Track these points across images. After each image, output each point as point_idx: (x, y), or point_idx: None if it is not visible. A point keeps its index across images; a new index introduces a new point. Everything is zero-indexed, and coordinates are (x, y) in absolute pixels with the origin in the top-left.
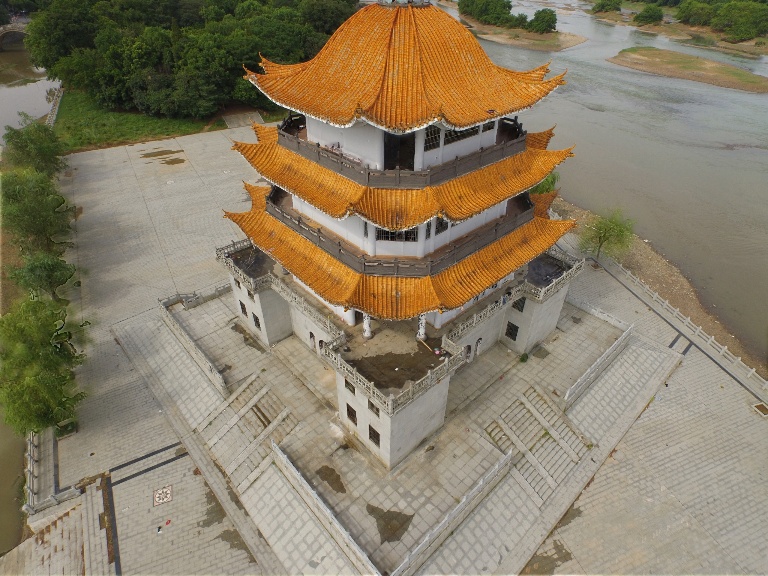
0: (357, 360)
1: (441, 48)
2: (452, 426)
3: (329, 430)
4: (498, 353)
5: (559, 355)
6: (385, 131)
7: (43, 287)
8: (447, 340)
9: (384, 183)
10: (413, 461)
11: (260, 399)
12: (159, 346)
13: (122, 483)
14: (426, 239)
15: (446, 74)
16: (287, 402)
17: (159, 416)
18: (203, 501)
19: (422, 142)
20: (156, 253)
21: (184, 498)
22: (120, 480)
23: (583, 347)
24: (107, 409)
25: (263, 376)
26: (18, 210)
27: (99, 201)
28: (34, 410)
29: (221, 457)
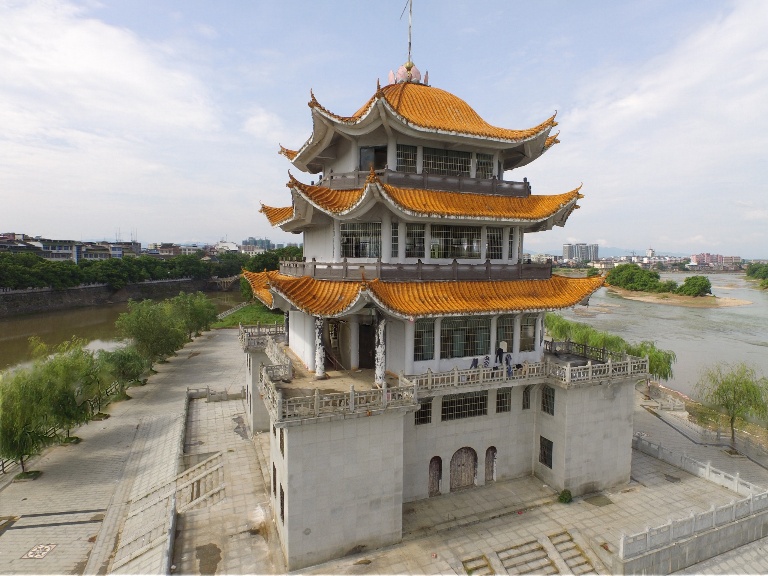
0: (289, 388)
1: (425, 100)
2: (414, 546)
3: (250, 512)
4: (526, 485)
5: (628, 507)
6: (361, 155)
7: (117, 377)
8: (403, 379)
9: (344, 185)
10: (329, 569)
11: (207, 475)
12: (165, 431)
13: (19, 529)
14: (392, 257)
15: (425, 113)
16: (229, 479)
17: (112, 484)
18: (69, 569)
19: (393, 160)
20: (227, 381)
21: (55, 560)
22: (20, 526)
23: (675, 507)
24: (76, 469)
25: (226, 455)
26: (141, 326)
27: (216, 351)
28: (0, 417)
29: (128, 529)
